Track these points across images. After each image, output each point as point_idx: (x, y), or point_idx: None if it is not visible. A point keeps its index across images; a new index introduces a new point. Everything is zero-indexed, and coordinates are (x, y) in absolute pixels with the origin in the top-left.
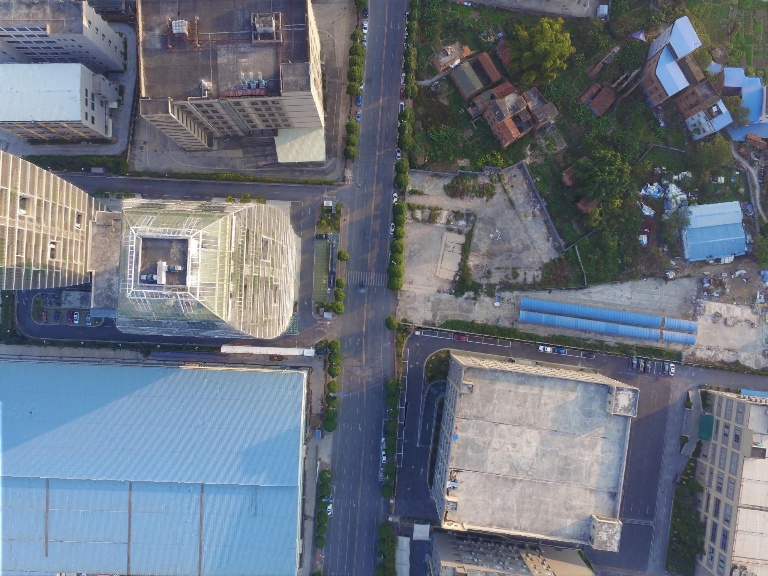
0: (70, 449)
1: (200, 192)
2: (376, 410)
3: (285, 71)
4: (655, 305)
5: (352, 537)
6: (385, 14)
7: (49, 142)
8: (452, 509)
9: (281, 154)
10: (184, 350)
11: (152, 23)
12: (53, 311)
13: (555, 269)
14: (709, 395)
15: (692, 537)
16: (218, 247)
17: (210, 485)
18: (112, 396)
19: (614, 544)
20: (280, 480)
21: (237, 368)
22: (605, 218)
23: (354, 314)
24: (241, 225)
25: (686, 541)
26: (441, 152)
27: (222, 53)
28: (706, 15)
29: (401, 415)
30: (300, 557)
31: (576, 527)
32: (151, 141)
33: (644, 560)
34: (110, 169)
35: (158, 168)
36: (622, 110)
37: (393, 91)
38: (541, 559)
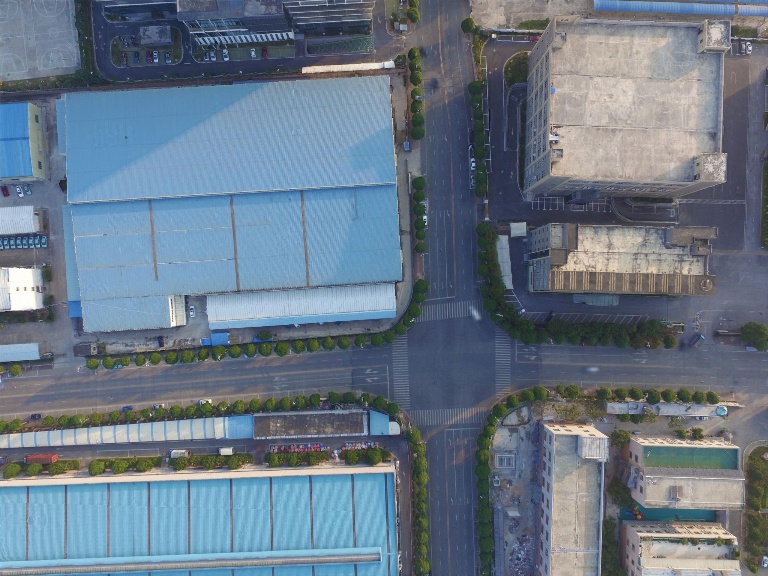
0: (169, 168)
1: None
2: (460, 120)
3: None
4: None
5: (450, 247)
6: None
7: None
8: (558, 156)
9: None
10: (267, 72)
11: None
12: (132, 53)
13: None
14: None
15: None
16: None
17: (309, 192)
18: (204, 114)
19: (721, 174)
20: (378, 177)
21: None
22: None
23: (428, 27)
24: None
25: None
26: None
27: None
28: None
29: (485, 122)
30: None
31: (680, 170)
32: None
33: (739, 239)
34: None
35: None
36: None
37: None
38: None
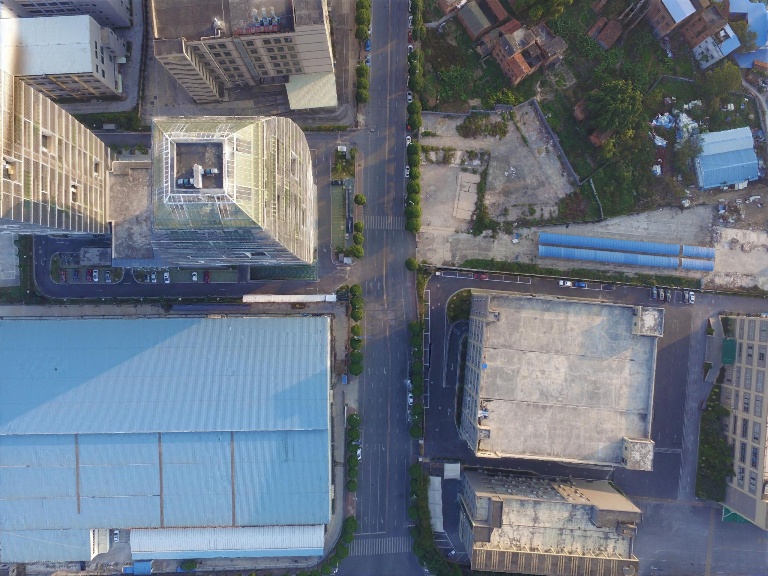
0: (97, 403)
1: None
2: (400, 353)
3: (297, 5)
4: (672, 234)
5: (383, 481)
6: None
7: (59, 101)
8: (485, 437)
9: (293, 101)
10: (206, 301)
11: None
12: (72, 270)
13: (571, 204)
14: (730, 321)
15: (721, 460)
16: (252, 152)
17: (240, 433)
18: (137, 349)
19: (647, 463)
20: (310, 424)
21: (260, 317)
22: (618, 150)
23: (373, 258)
24: (272, 134)
25: (715, 464)
26: (452, 92)
27: None
28: None
29: (425, 357)
30: (332, 503)
31: (608, 450)
32: (161, 96)
33: (674, 488)
34: (122, 125)
35: None
36: (629, 43)
37: (401, 35)
38: (573, 489)
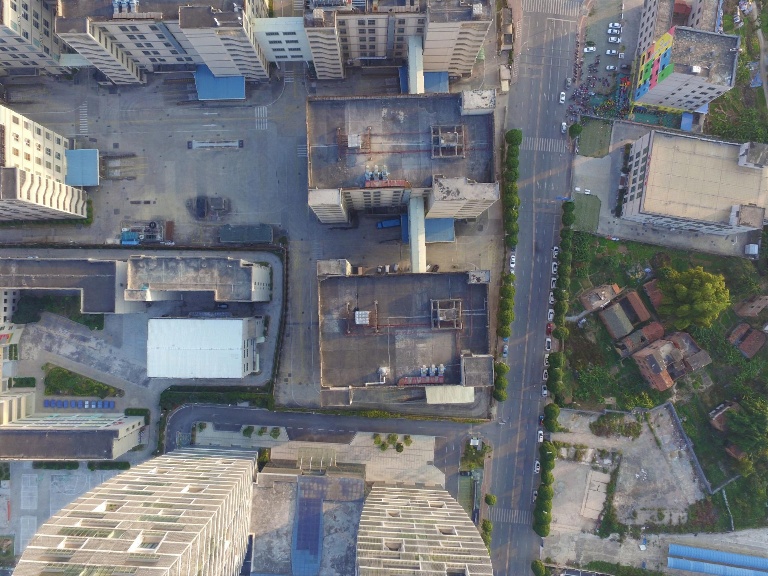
0: None
1: (344, 426)
2: None
3: (468, 365)
4: None
5: None
6: (532, 247)
7: None
8: None
9: (430, 395)
10: None
11: (330, 306)
12: None
13: (701, 511)
14: None
15: None
16: None
17: None
18: None
19: None
20: None
21: None
22: (753, 462)
23: (497, 552)
24: None
25: None
26: (590, 394)
27: (400, 338)
28: None
29: None
30: None
31: None
32: (296, 373)
33: None
34: (255, 402)
35: (302, 401)
36: None
37: (539, 326)
38: None
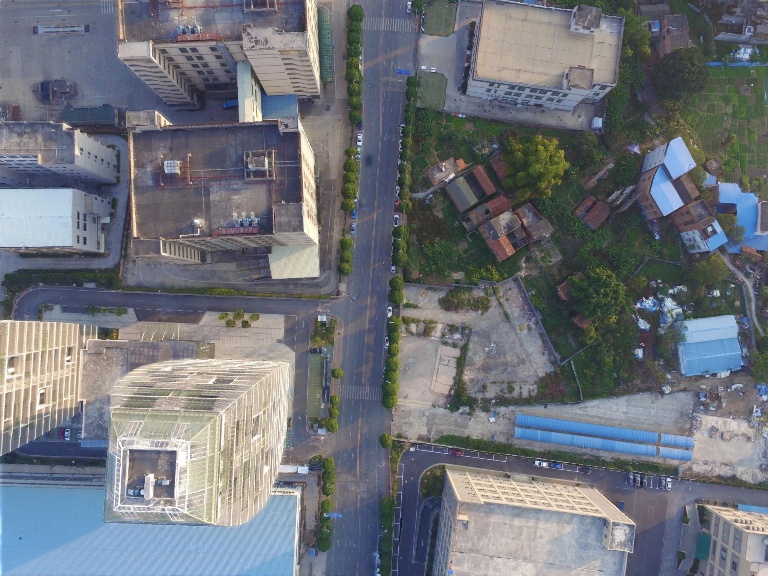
0: (60, 575)
1: (193, 306)
2: (371, 526)
3: (278, 212)
4: (651, 419)
5: None
6: (379, 126)
7: (41, 256)
8: None
9: (275, 270)
10: None
11: (144, 160)
12: None
13: (551, 383)
14: (706, 511)
15: None
16: (207, 452)
17: None
18: None
19: None
20: None
21: None
22: (601, 332)
23: (348, 429)
24: (231, 420)
25: None
26: (436, 267)
27: (214, 190)
28: (700, 125)
29: (396, 531)
30: None
31: None
32: None
33: None
34: (102, 283)
35: (151, 282)
36: (617, 222)
37: (387, 203)
38: None
